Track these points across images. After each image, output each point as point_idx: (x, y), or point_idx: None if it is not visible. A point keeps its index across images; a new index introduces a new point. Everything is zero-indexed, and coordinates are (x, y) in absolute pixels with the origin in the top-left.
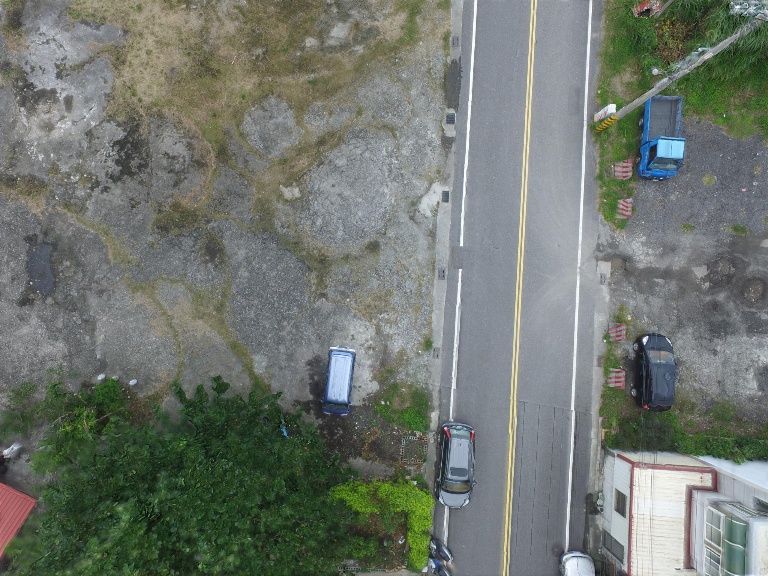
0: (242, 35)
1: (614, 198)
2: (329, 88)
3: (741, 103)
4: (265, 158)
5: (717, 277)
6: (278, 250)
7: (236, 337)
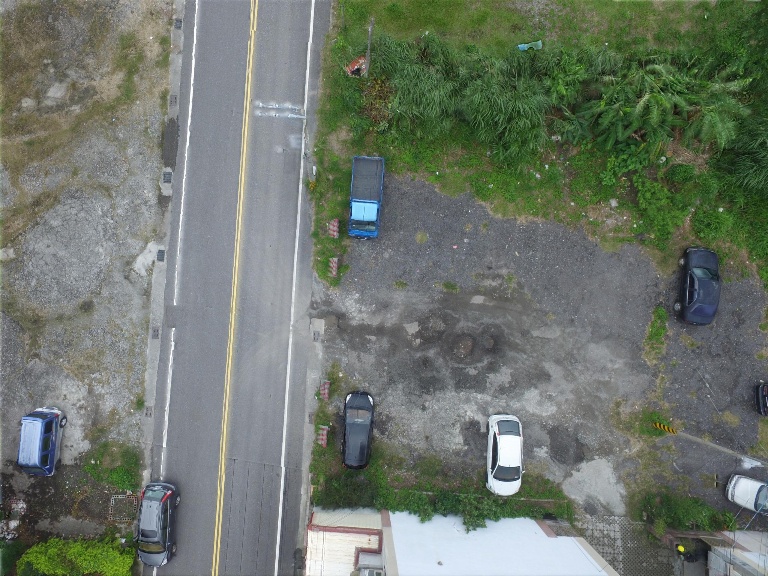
0: None
1: (327, 256)
2: (45, 148)
3: (454, 160)
4: None
5: (428, 333)
6: None
7: None
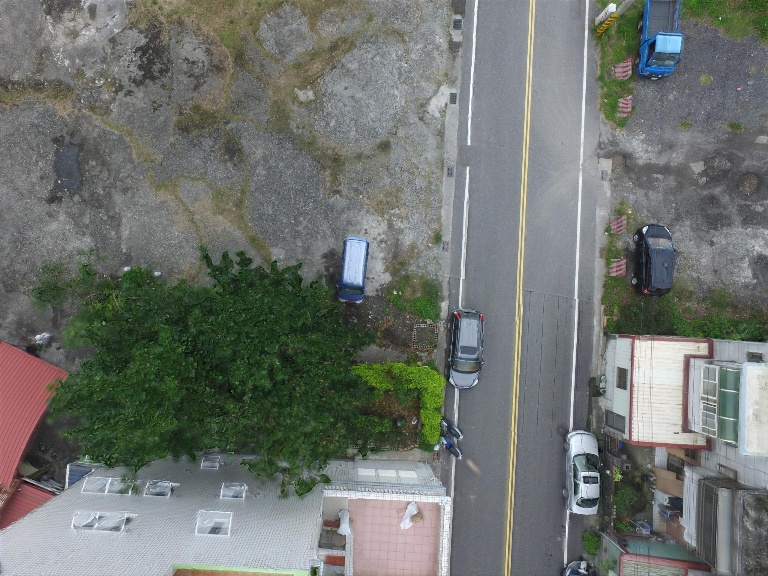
0: None
1: (615, 98)
2: None
3: (736, 6)
4: (280, 62)
5: (713, 172)
6: (294, 150)
7: (255, 232)
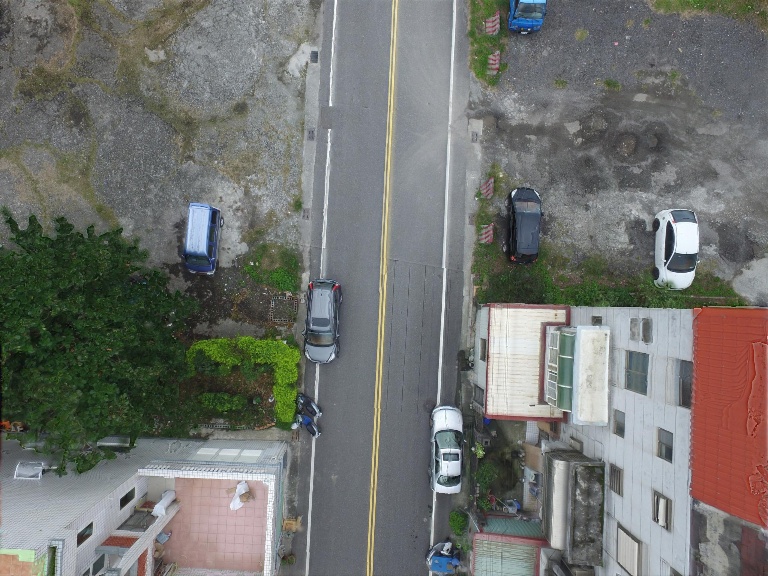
0: None
1: (485, 54)
2: None
3: None
4: (129, 20)
5: (590, 133)
6: (144, 113)
7: (102, 201)
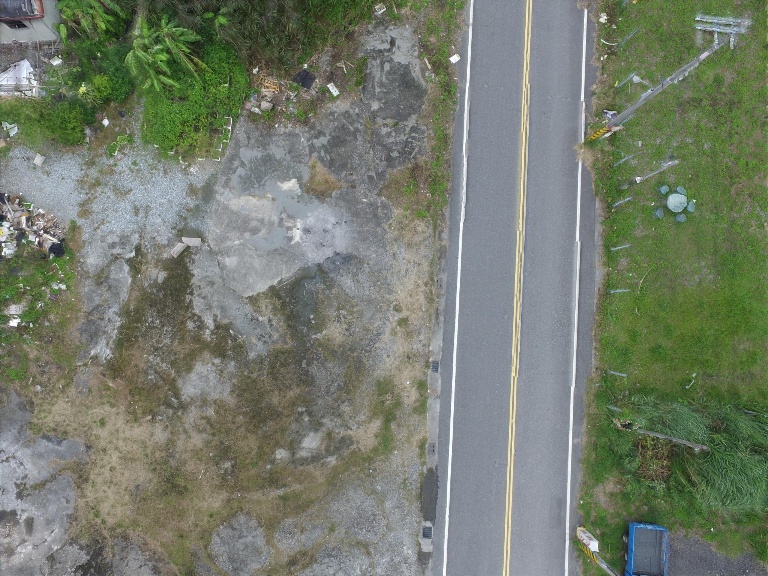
0: (210, 448)
1: None
2: (300, 503)
3: (729, 515)
4: None
5: None
6: None
7: None
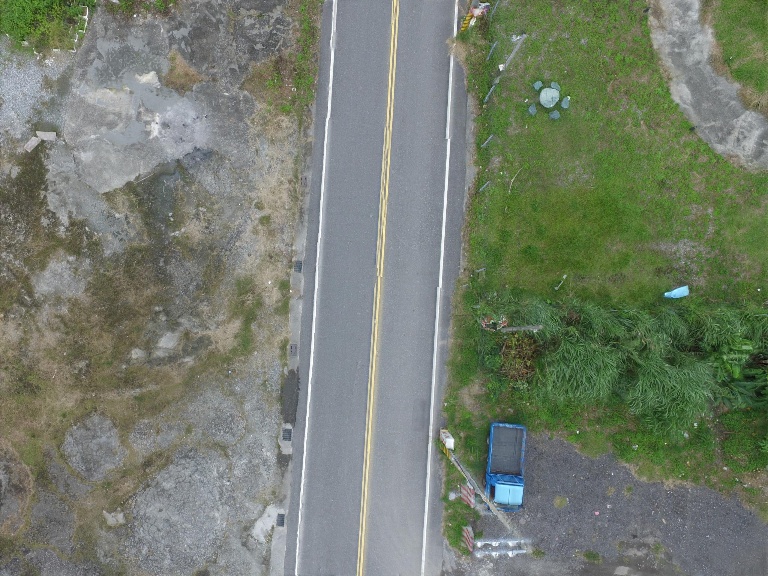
0: (63, 347)
1: (459, 523)
2: (157, 403)
3: (595, 418)
4: (87, 481)
5: None
6: None
7: None
